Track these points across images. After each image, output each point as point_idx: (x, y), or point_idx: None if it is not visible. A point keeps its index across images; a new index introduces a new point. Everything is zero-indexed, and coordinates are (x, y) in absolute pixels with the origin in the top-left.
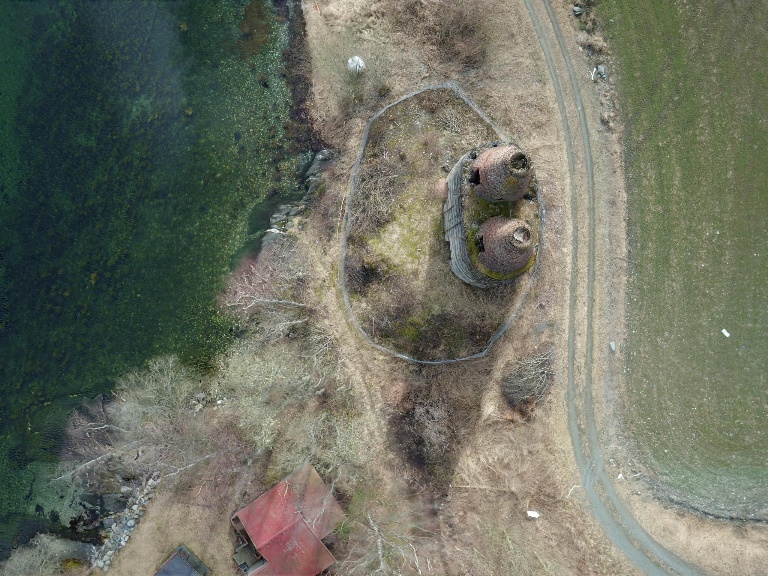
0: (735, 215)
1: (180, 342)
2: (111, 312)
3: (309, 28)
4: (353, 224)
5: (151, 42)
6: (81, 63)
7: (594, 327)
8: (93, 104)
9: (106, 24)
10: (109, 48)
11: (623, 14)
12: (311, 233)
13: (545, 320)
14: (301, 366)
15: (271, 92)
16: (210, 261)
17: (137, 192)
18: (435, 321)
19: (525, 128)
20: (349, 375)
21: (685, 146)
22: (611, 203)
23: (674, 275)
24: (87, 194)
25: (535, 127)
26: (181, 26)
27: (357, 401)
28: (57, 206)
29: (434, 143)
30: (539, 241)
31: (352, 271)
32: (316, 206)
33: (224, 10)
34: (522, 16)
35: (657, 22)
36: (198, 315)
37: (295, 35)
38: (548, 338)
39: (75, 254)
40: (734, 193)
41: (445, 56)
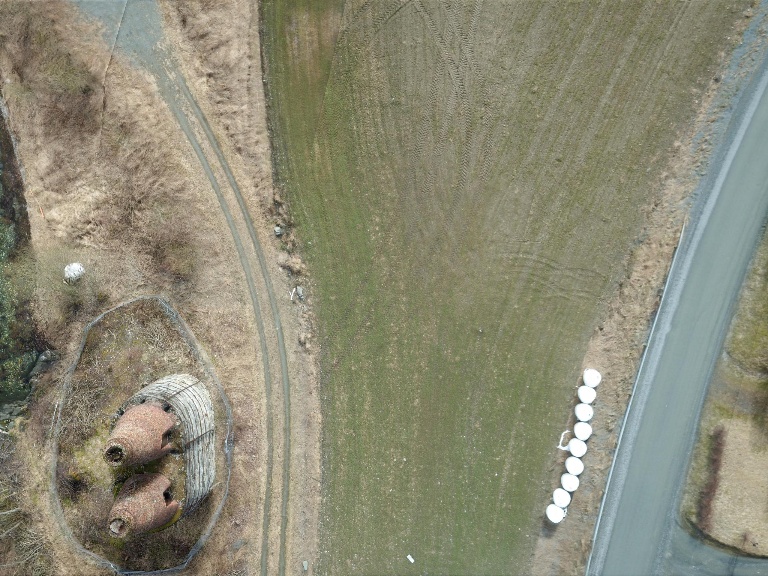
0: (421, 443)
1: None
2: None
3: (33, 231)
4: (61, 434)
5: None
6: None
7: (287, 546)
8: None
9: None
10: None
11: (320, 237)
12: (30, 435)
13: (240, 538)
14: (15, 569)
15: None
16: None
17: None
18: None
19: (225, 346)
20: None
21: (375, 372)
22: (307, 423)
23: (364, 498)
24: None
25: (235, 346)
26: None
27: None
28: None
29: (138, 358)
30: None
31: None
32: (35, 409)
33: None
34: (224, 235)
35: (351, 247)
36: None
37: (20, 237)
38: (243, 556)
39: None
40: (420, 421)
41: (158, 266)
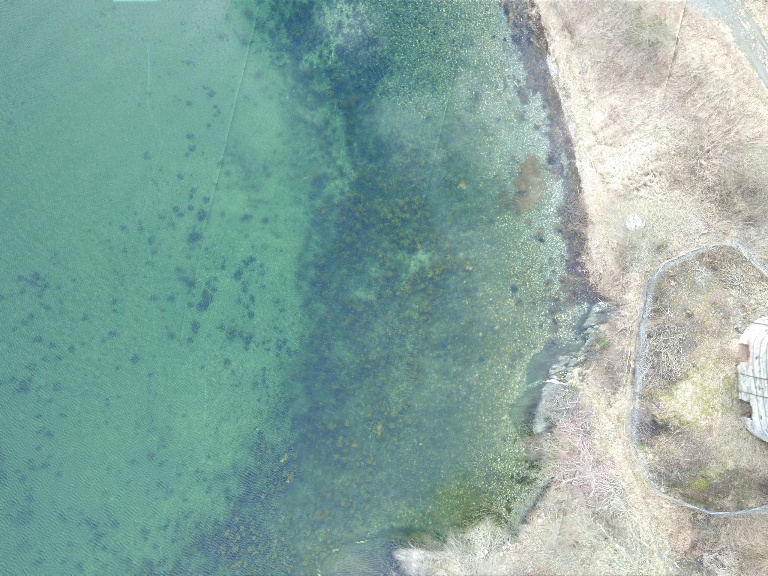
0: None
1: (462, 489)
2: (394, 460)
3: (585, 185)
4: (643, 380)
5: (428, 199)
6: (362, 221)
7: None
8: (372, 260)
9: (384, 182)
10: (387, 205)
11: None
12: (593, 385)
13: None
14: (590, 515)
15: (547, 246)
16: (490, 410)
17: (418, 345)
18: (727, 475)
19: None
20: (637, 523)
21: None
22: None
23: None
24: (368, 347)
25: None
26: (460, 185)
27: (645, 548)
28: (339, 359)
29: (723, 303)
30: None
31: (640, 424)
32: (597, 359)
33: (499, 167)
34: None
35: None
36: (479, 462)
37: (570, 191)
38: None
39: (357, 405)
40: None
41: (724, 214)
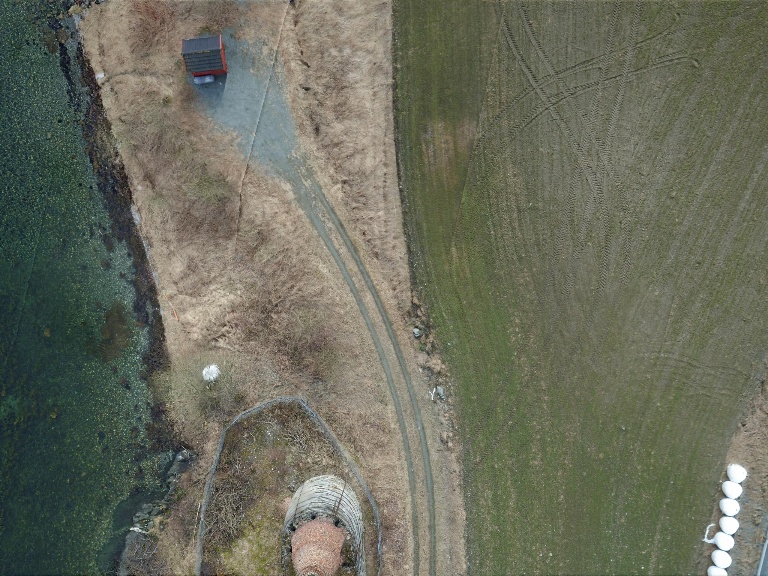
0: (567, 538)
1: None
2: None
3: (167, 334)
4: (207, 536)
5: (17, 345)
6: None
7: None
8: None
9: None
10: None
11: (460, 339)
12: (171, 535)
13: None
14: None
15: (133, 394)
16: (77, 557)
17: (5, 491)
18: None
19: (368, 447)
20: None
21: (519, 469)
22: (451, 520)
23: None
24: None
25: (378, 446)
26: (44, 333)
27: None
28: None
29: (282, 461)
30: (379, 564)
31: None
32: (175, 509)
33: (87, 314)
34: (364, 338)
35: (491, 348)
36: None
37: (155, 340)
38: None
39: None
40: (565, 517)
41: (295, 367)
